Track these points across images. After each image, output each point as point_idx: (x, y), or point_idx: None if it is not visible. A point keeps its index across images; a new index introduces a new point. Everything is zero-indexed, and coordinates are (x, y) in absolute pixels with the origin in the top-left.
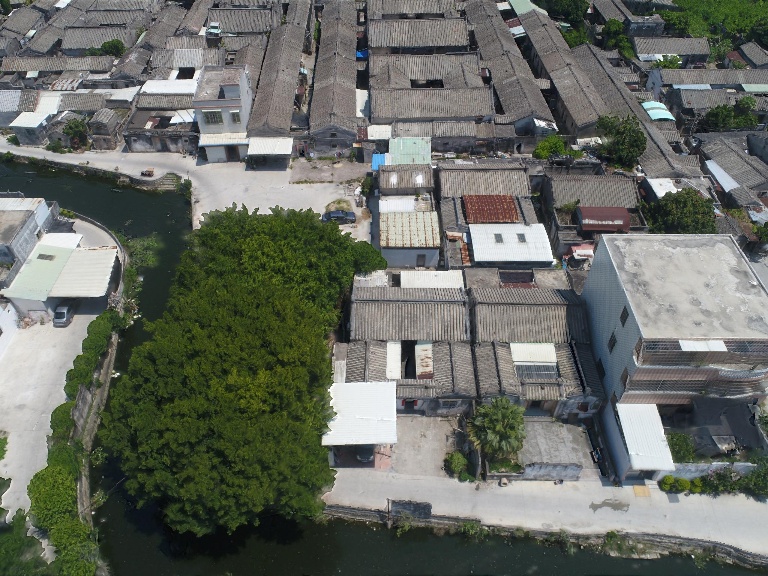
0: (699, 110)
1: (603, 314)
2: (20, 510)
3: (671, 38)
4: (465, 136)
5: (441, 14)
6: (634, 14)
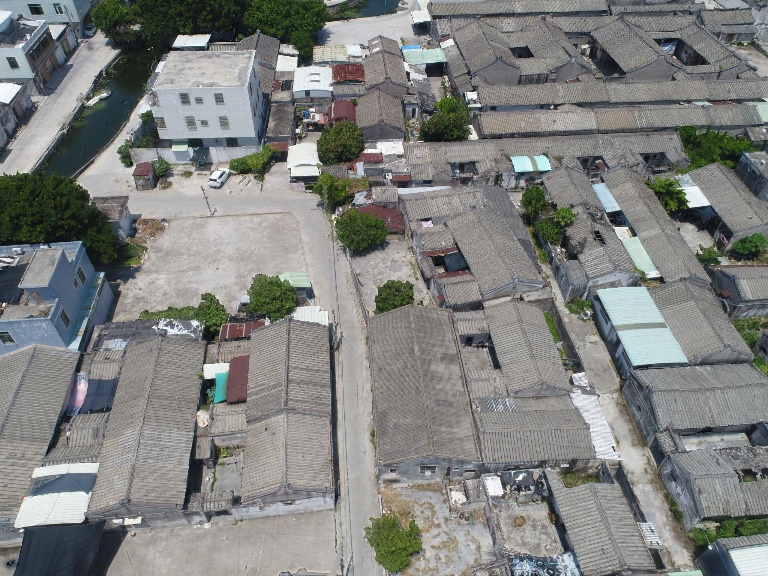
0: (545, 189)
1: None
2: None
3: (739, 192)
4: None
5: None
6: None
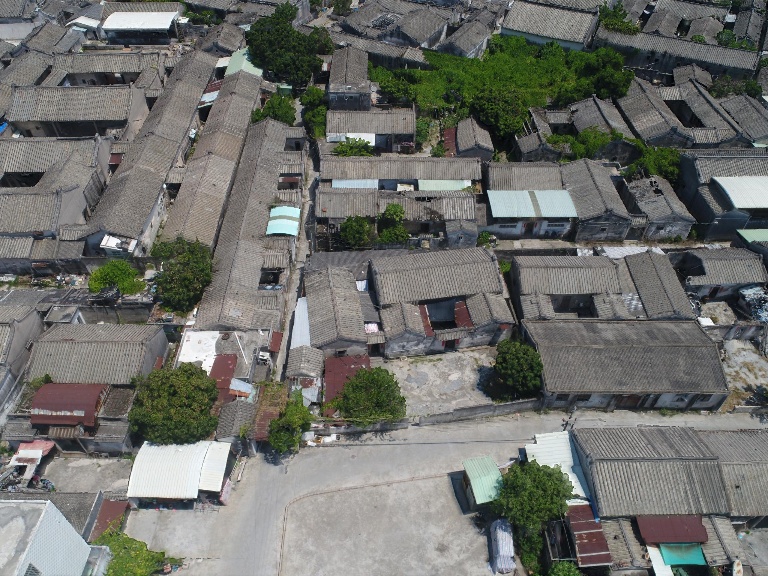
0: (336, 220)
1: None
2: None
3: (372, 112)
4: (13, 258)
5: (140, 73)
6: (388, 70)
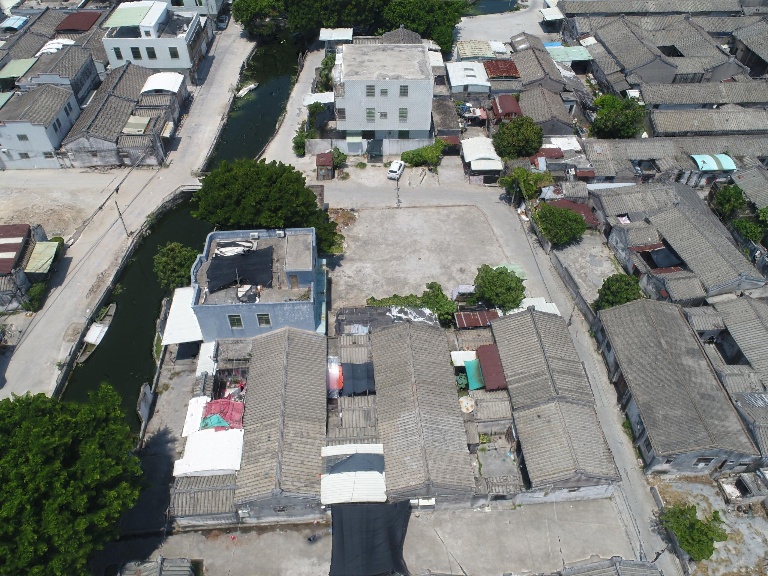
0: None
1: None
2: None
3: None
4: None
5: None
6: None
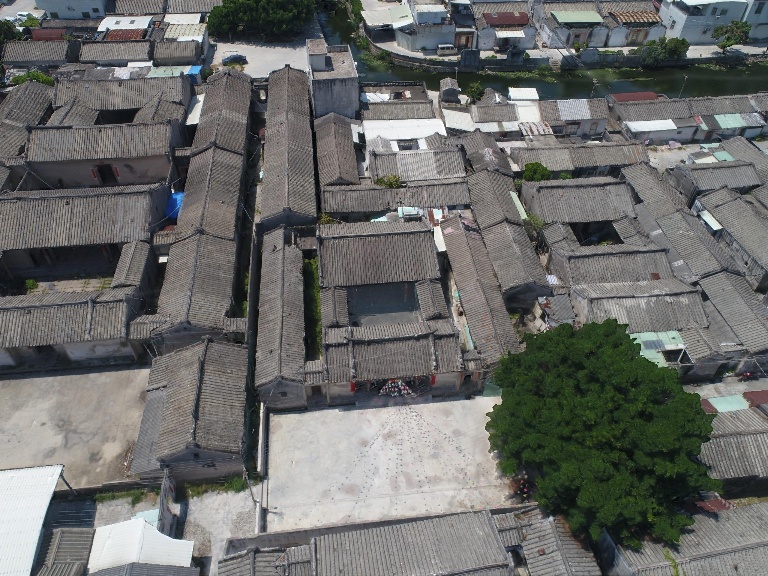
0: None
1: None
2: None
3: None
4: None
5: None
6: None
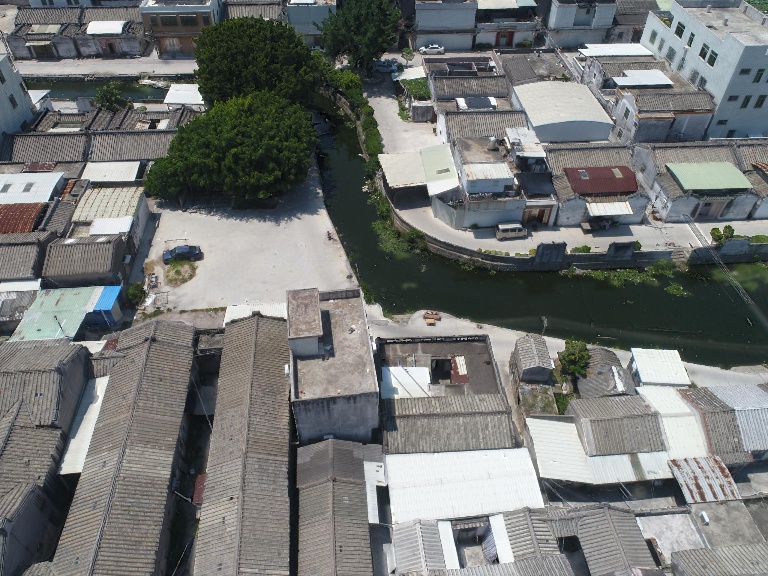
0: None
1: (2, 112)
2: (332, 28)
3: None
4: None
5: None
6: None
